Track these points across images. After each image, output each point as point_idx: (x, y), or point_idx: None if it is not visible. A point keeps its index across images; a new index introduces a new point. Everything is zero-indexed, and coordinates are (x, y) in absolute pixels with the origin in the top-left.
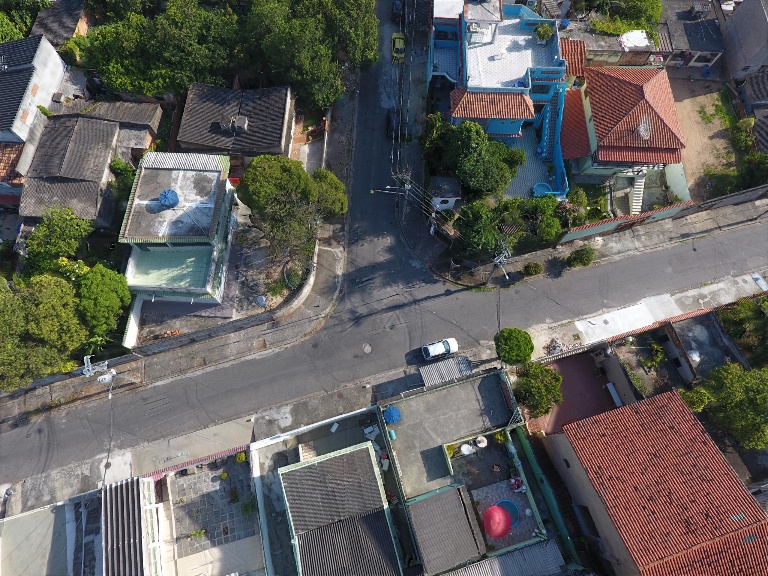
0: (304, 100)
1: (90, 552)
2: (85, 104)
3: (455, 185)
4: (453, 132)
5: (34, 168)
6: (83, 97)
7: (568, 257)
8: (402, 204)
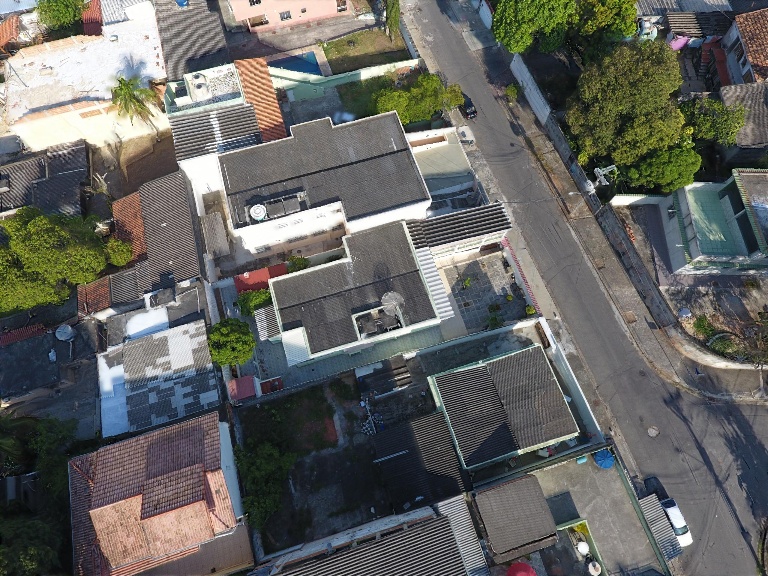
0: None
1: (441, 205)
2: None
3: None
4: None
5: None
6: None
7: None
8: None
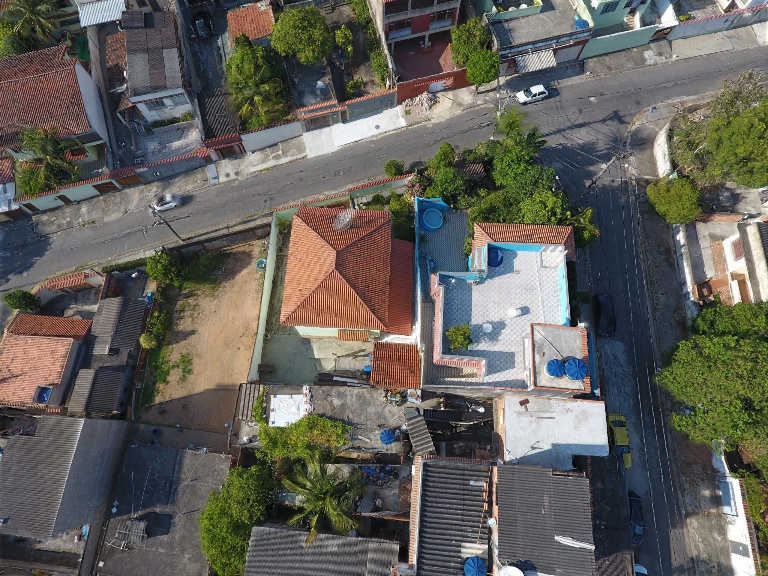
0: None
1: None
2: None
3: None
4: None
5: None
6: None
7: None
8: None
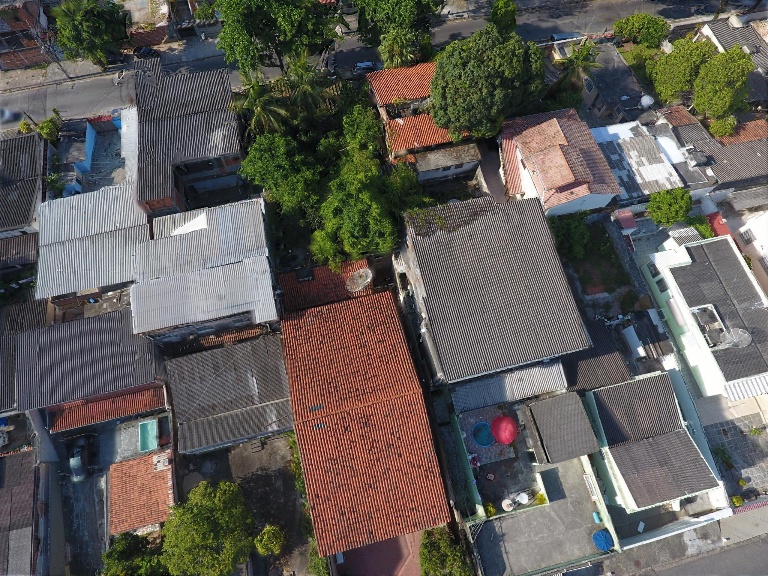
0: None
1: None
2: None
3: None
4: None
5: None
6: None
7: None
8: None
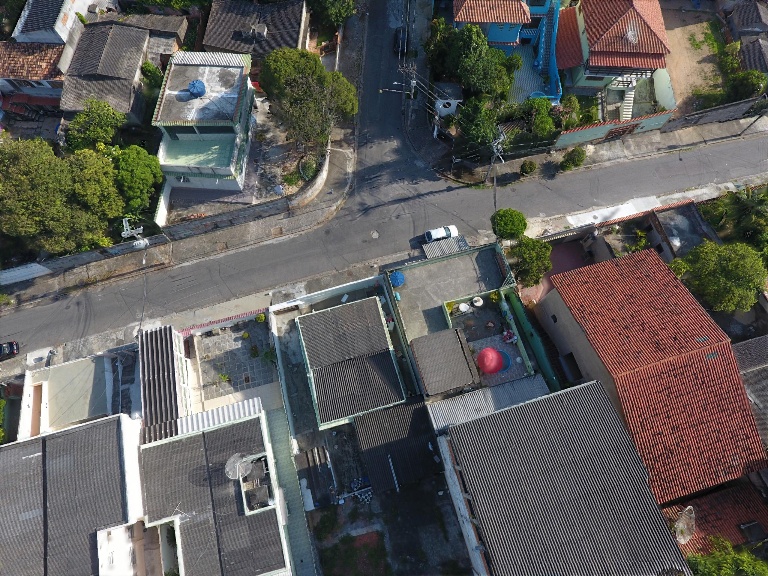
0: (318, 16)
1: (126, 397)
2: (118, 16)
3: (457, 89)
4: (455, 34)
5: (73, 68)
6: (115, 11)
7: (561, 161)
8: (408, 112)
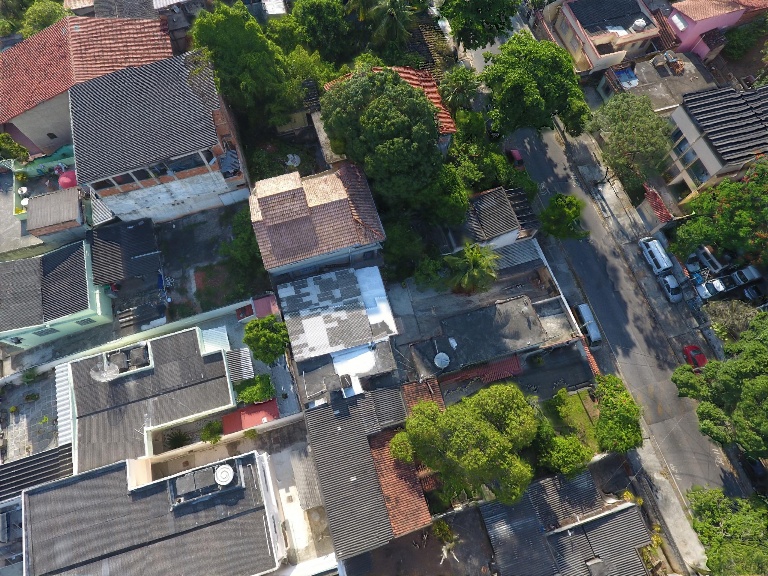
0: None
1: None
2: None
3: None
4: None
5: None
6: None
7: None
8: None
